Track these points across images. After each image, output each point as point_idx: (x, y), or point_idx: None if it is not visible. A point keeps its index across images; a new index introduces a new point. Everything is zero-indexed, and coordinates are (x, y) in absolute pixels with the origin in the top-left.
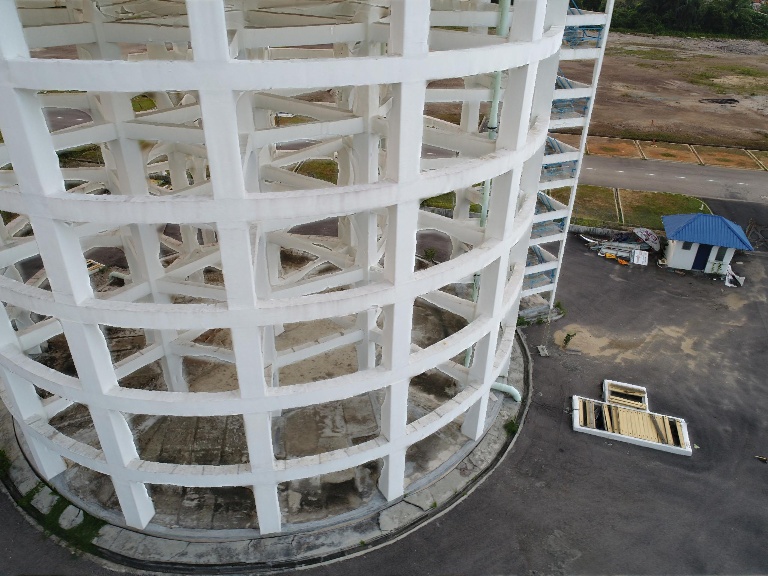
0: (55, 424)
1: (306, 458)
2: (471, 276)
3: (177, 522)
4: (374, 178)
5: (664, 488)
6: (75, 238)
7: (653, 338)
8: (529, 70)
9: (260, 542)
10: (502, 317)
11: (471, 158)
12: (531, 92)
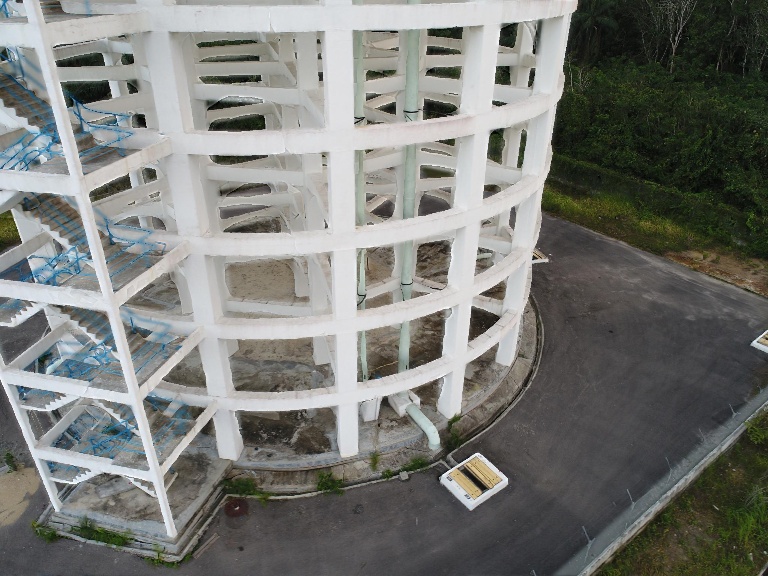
0: None
1: None
2: None
3: None
4: None
5: None
6: None
7: None
8: None
9: None
10: None
11: None
12: None
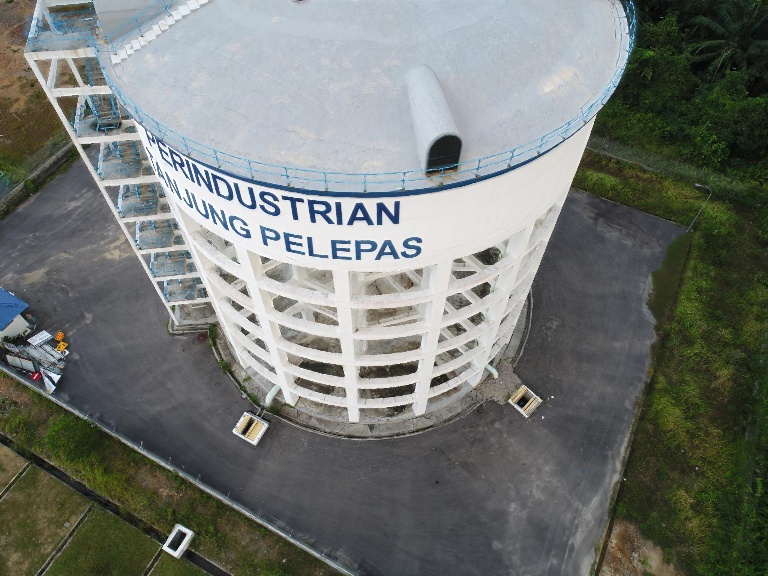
0: None
1: None
2: None
3: None
4: None
5: None
6: None
7: None
8: None
9: None
10: None
11: None
12: None
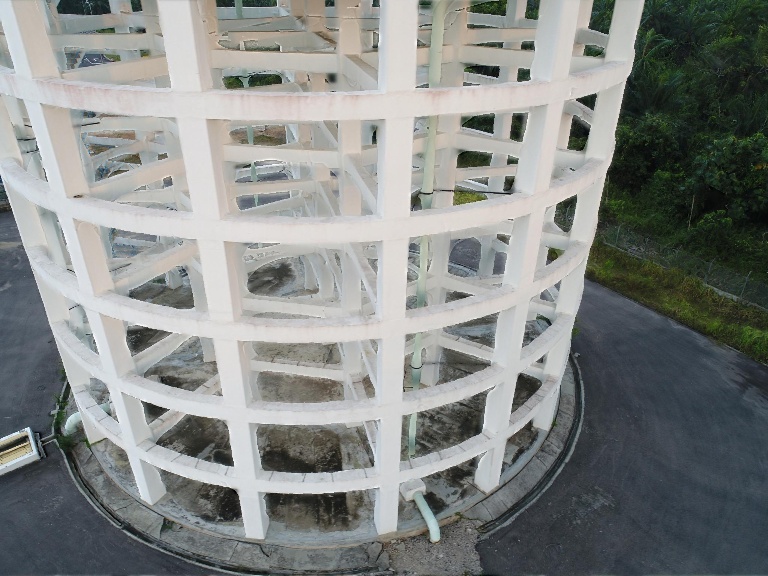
0: (526, 344)
1: None
2: None
3: (468, 274)
4: None
5: None
6: None
7: None
8: None
9: None
10: None
11: None
12: None
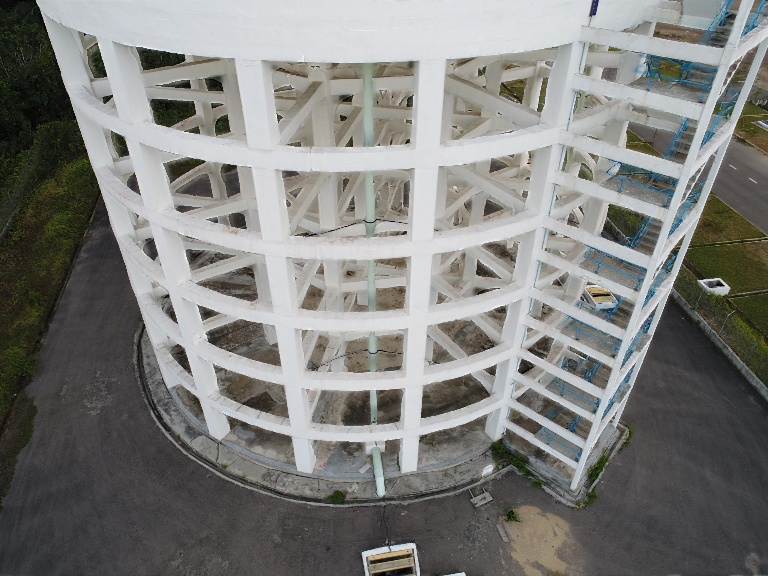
0: None
1: (169, 355)
2: (479, 374)
3: None
4: (327, 213)
5: None
6: (111, 152)
7: None
8: (256, 173)
9: (162, 384)
10: (308, 387)
11: (487, 255)
12: (271, 195)
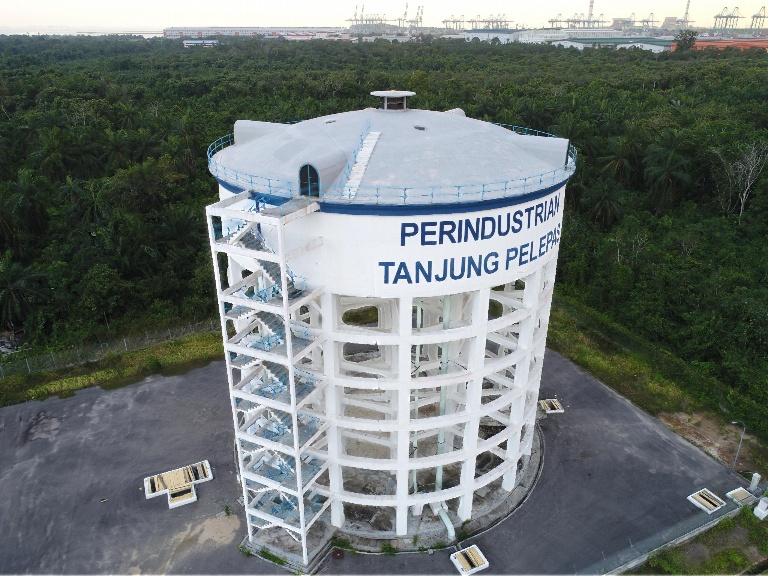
0: None
1: None
2: None
3: None
4: None
5: (160, 459)
6: None
7: (164, 567)
8: None
9: None
10: None
11: None
12: None
